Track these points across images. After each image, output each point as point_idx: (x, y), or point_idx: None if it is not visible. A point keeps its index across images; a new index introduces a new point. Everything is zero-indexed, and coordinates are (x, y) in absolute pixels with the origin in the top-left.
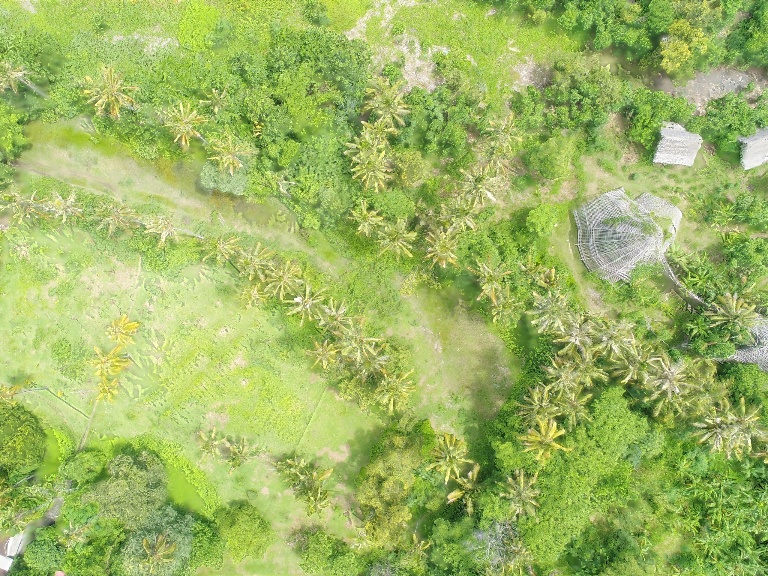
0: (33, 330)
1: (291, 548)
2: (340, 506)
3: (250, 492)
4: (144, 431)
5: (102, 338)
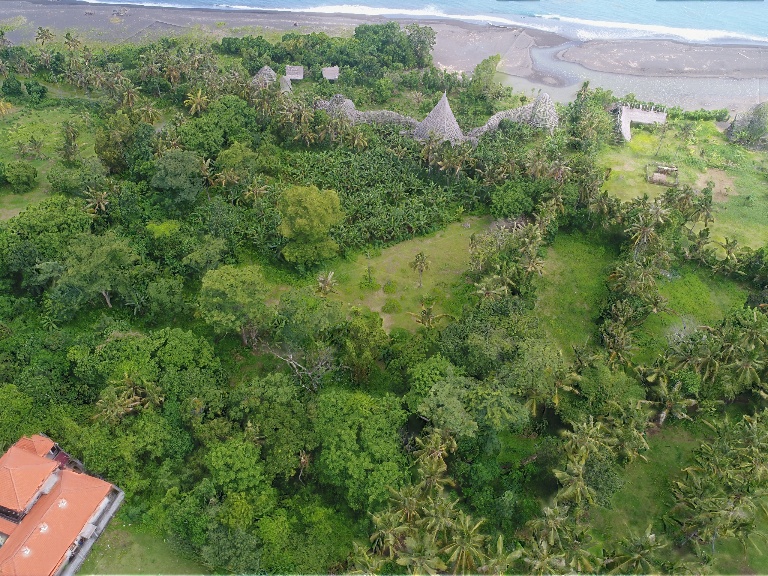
0: None
1: (46, 193)
2: None
3: None
4: None
5: None
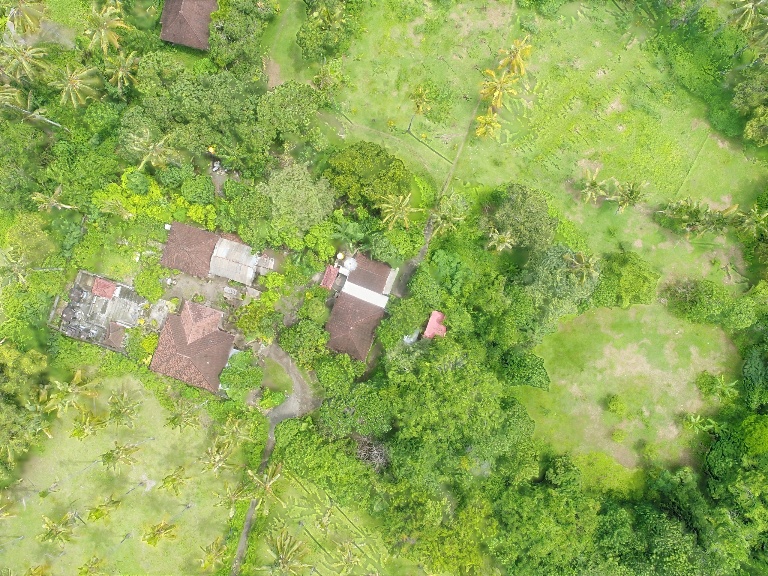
0: (396, 70)
1: (663, 305)
2: (719, 260)
3: (626, 242)
4: (511, 179)
5: (469, 80)
